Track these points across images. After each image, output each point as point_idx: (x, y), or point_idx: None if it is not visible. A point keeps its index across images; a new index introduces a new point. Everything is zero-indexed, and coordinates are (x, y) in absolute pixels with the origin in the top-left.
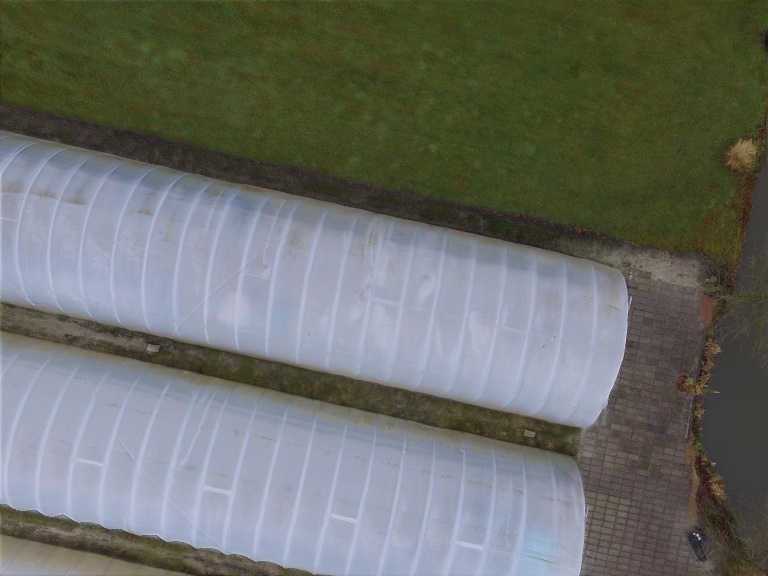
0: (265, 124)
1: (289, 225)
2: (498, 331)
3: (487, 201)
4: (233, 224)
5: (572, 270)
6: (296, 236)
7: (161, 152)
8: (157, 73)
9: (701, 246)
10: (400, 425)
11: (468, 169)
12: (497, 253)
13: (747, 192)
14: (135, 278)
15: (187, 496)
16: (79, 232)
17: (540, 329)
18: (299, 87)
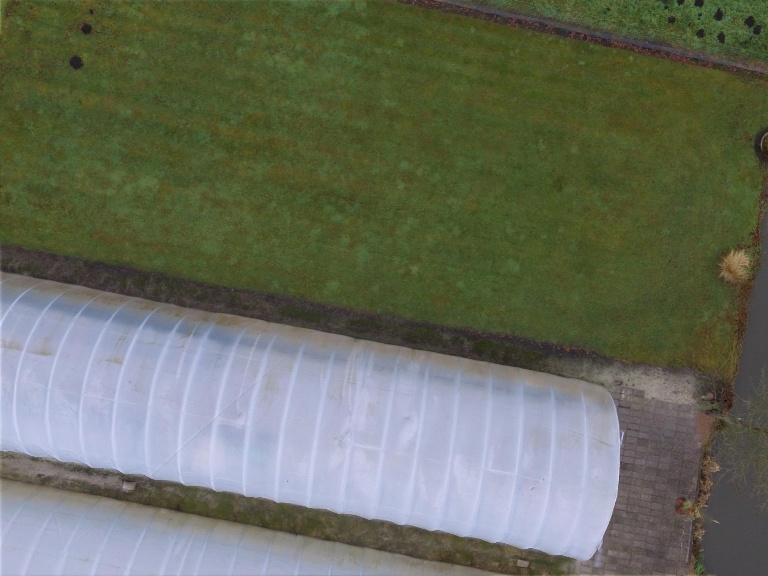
0: (238, 249)
1: (263, 367)
2: (484, 475)
3: (471, 322)
4: (205, 369)
5: (560, 400)
6: (271, 379)
7: (132, 282)
8: (126, 201)
9: (695, 361)
10: (387, 561)
11: (450, 289)
12: (482, 385)
13: (741, 303)
14: (105, 430)
15: None
16: (45, 385)
17: (528, 471)
18: (272, 210)
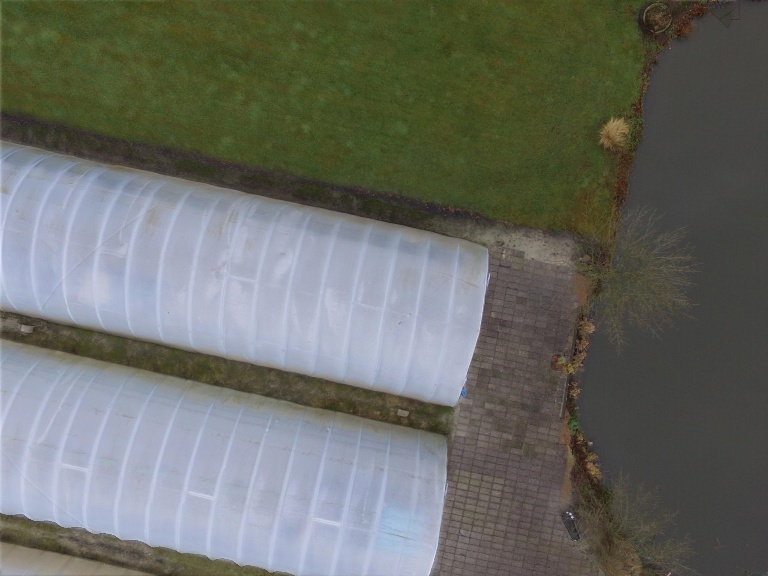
0: (138, 105)
1: (149, 204)
2: (354, 308)
3: (360, 181)
4: (91, 203)
5: (436, 248)
6: (154, 215)
7: (34, 134)
8: (30, 55)
9: (575, 225)
10: (271, 404)
11: (341, 149)
12: (360, 231)
13: (622, 171)
14: None
15: (45, 474)
16: None
17: (396, 306)
18: (171, 68)
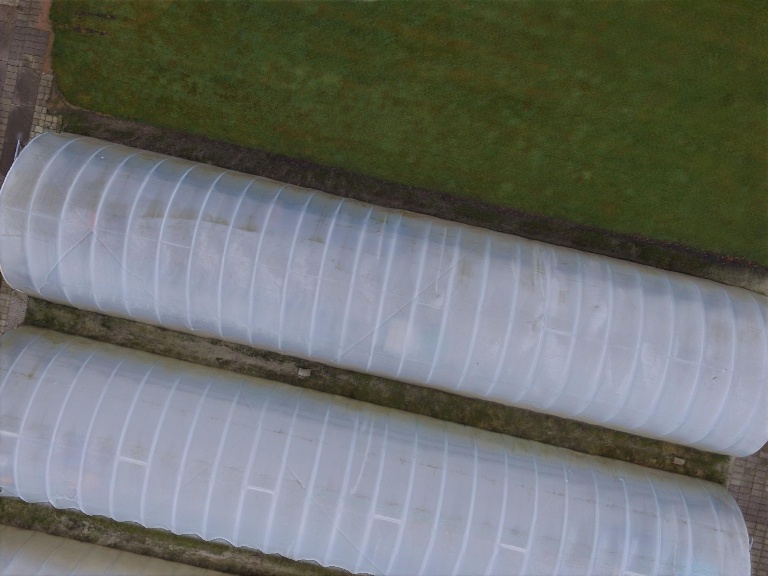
0: (418, 148)
1: (458, 253)
2: (670, 363)
3: (640, 228)
4: (403, 252)
5: (735, 300)
6: (466, 265)
7: (313, 175)
8: (310, 95)
9: None
10: (554, 452)
11: (621, 196)
12: (661, 283)
13: None
14: (306, 306)
15: (357, 524)
16: (252, 259)
17: (712, 361)
18: (453, 111)
